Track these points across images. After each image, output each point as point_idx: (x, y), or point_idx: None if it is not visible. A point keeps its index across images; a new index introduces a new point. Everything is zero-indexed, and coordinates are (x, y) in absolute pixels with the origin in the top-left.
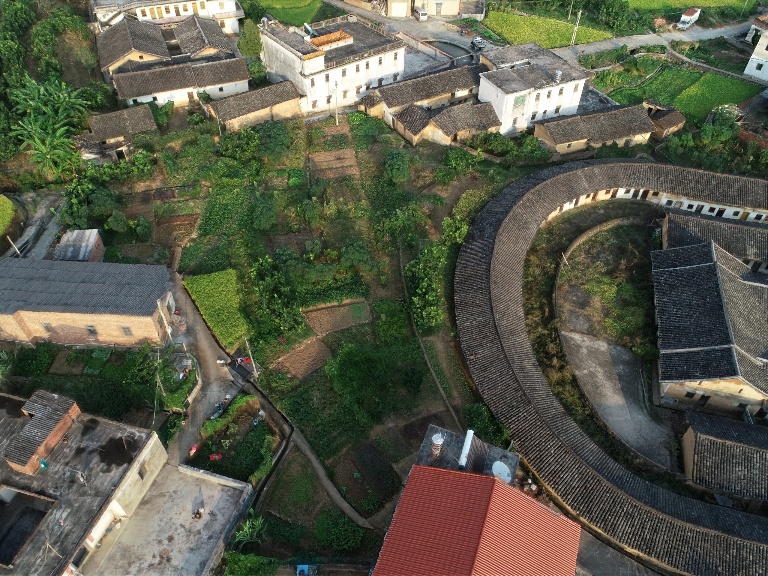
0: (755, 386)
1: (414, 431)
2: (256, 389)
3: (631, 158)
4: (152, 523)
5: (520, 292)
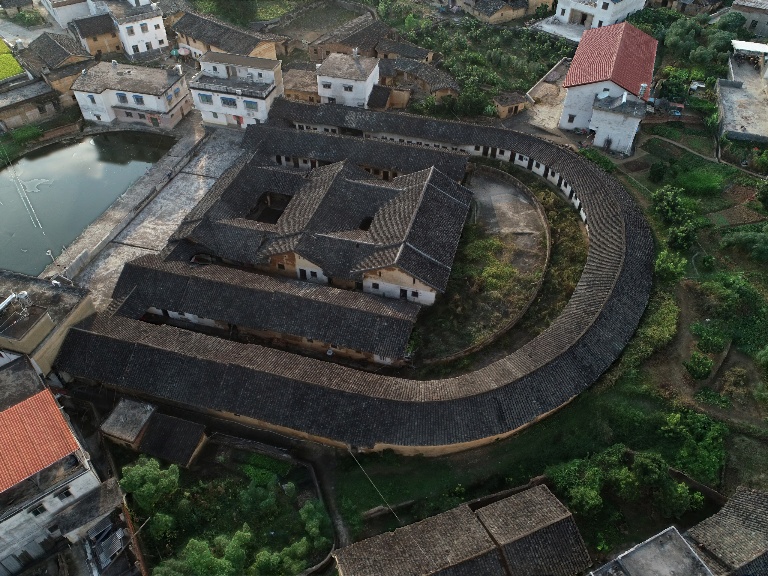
0: (419, 172)
1: (643, 164)
2: (760, 177)
3: (422, 443)
4: (763, 127)
5: (590, 223)
